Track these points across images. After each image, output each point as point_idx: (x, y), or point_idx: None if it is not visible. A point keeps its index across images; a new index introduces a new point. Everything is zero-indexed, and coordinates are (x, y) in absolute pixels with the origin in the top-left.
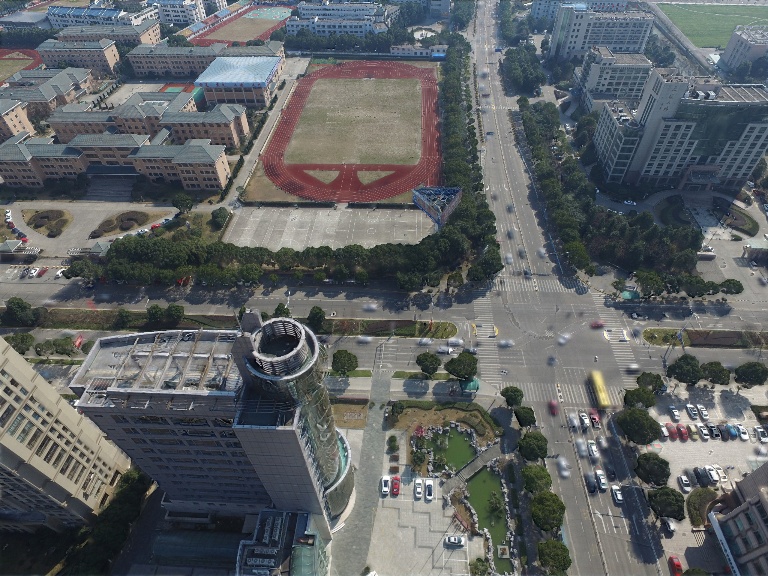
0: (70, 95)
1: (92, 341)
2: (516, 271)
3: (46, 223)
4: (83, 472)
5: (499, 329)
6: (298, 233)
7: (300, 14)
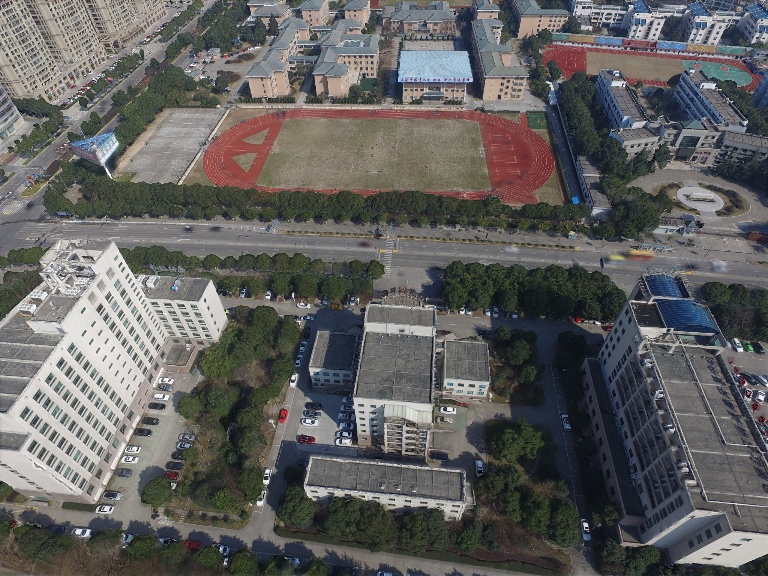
0: (411, 26)
1: (103, 80)
2: (56, 230)
3: (240, 58)
4: (1, 80)
5: (8, 215)
6: (179, 133)
7: (680, 82)
